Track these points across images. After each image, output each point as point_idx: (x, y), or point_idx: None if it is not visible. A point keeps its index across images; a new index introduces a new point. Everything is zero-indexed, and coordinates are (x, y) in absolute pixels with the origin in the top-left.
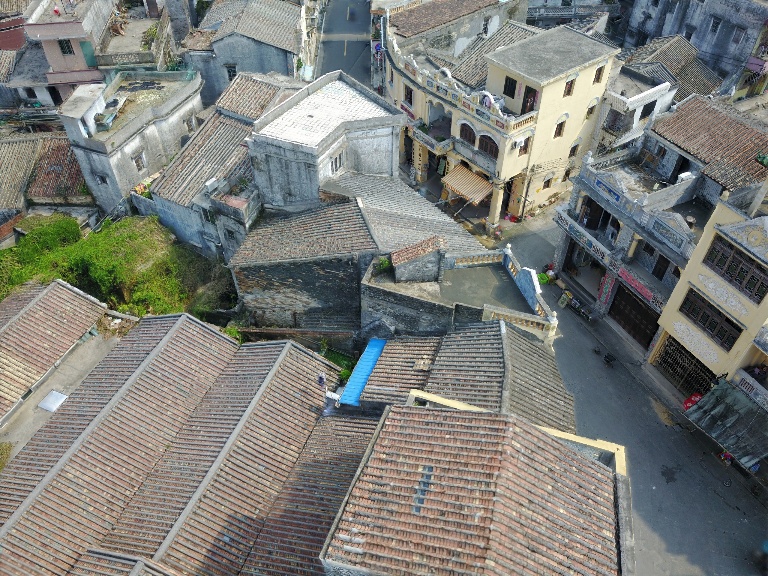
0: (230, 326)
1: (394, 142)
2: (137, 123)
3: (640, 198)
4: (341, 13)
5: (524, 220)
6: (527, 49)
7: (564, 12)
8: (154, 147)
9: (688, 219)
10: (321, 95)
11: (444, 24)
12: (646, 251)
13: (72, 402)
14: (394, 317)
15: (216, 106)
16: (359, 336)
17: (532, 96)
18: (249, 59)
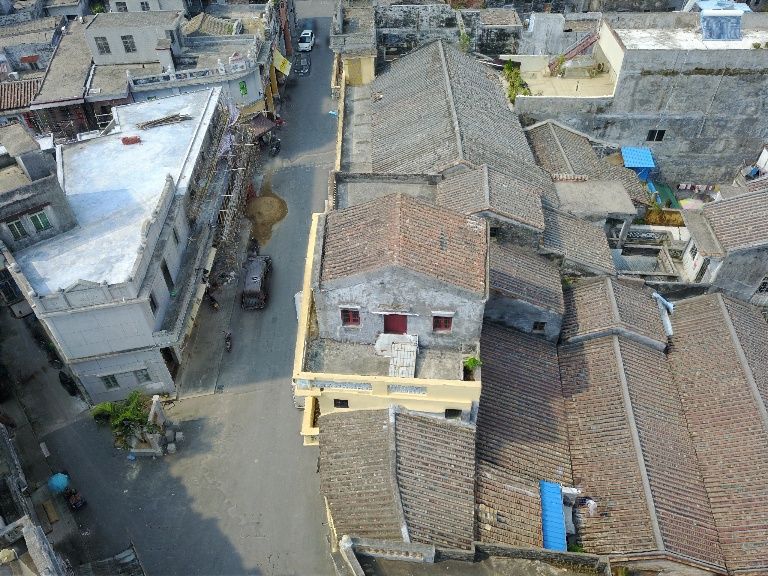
0: None
1: None
2: None
3: None
4: None
5: None
6: None
7: None
8: None
9: None
10: None
11: None
12: None
13: None
14: None
15: None
16: None
17: None
18: None
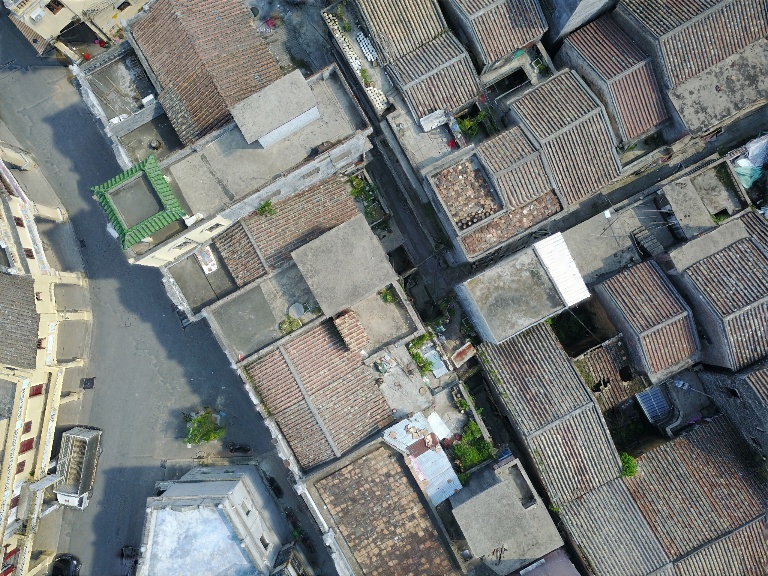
0: None
1: None
2: None
3: None
4: None
5: (113, 44)
6: None
7: None
8: None
9: (152, 143)
10: None
11: None
12: None
13: None
14: None
15: None
16: None
17: None
18: None
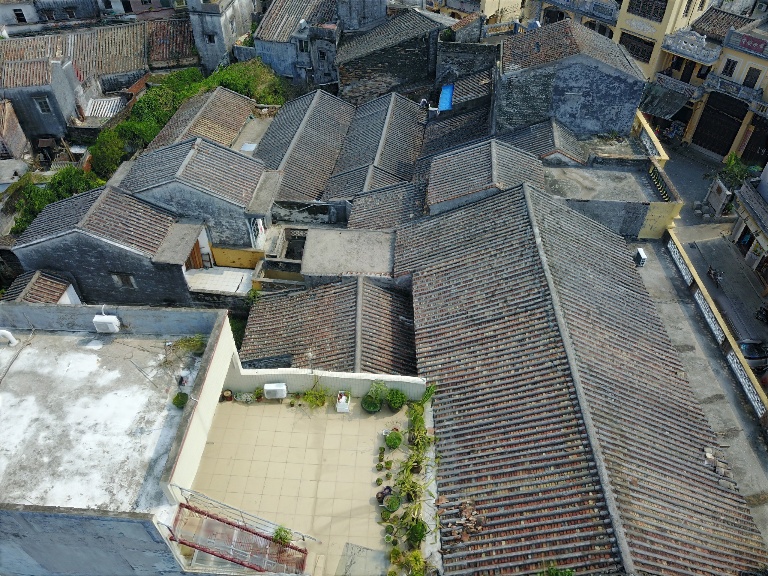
0: None
1: None
2: None
3: None
4: None
5: None
6: None
7: None
8: (238, 18)
9: None
10: None
11: None
12: None
13: (267, 140)
14: (458, 65)
15: None
16: (434, 87)
17: None
18: None
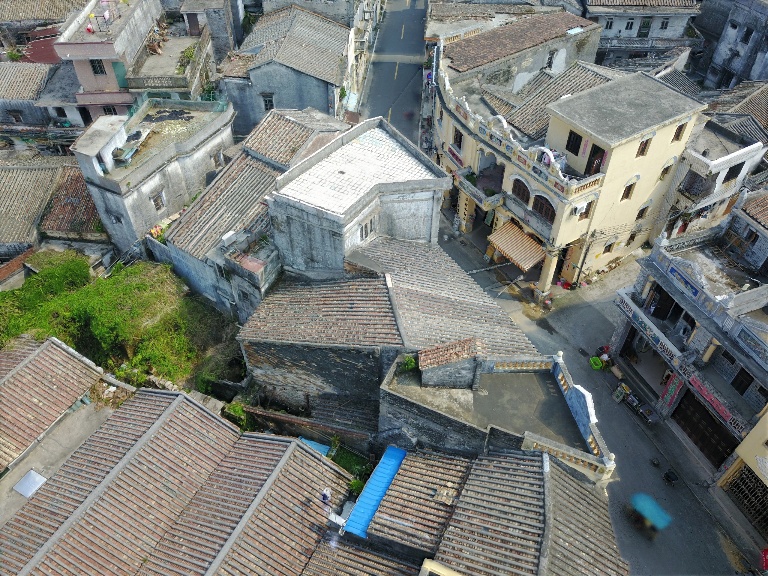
0: (236, 402)
1: (435, 207)
2: (158, 160)
3: (723, 295)
4: (395, 31)
5: (579, 288)
6: (597, 99)
7: (639, 44)
8: (176, 184)
9: None
10: (357, 146)
11: (504, 58)
12: (726, 357)
13: (48, 491)
14: (417, 428)
15: (244, 145)
16: (376, 440)
17: (599, 157)
18: (287, 89)
